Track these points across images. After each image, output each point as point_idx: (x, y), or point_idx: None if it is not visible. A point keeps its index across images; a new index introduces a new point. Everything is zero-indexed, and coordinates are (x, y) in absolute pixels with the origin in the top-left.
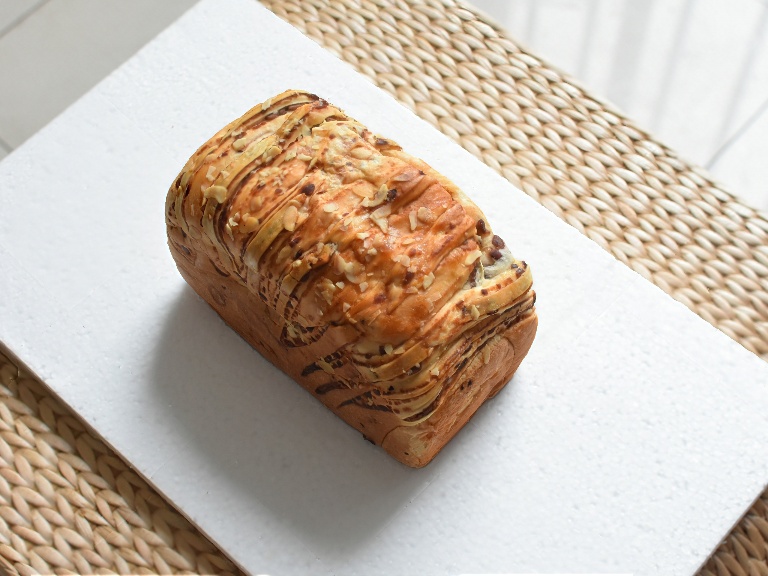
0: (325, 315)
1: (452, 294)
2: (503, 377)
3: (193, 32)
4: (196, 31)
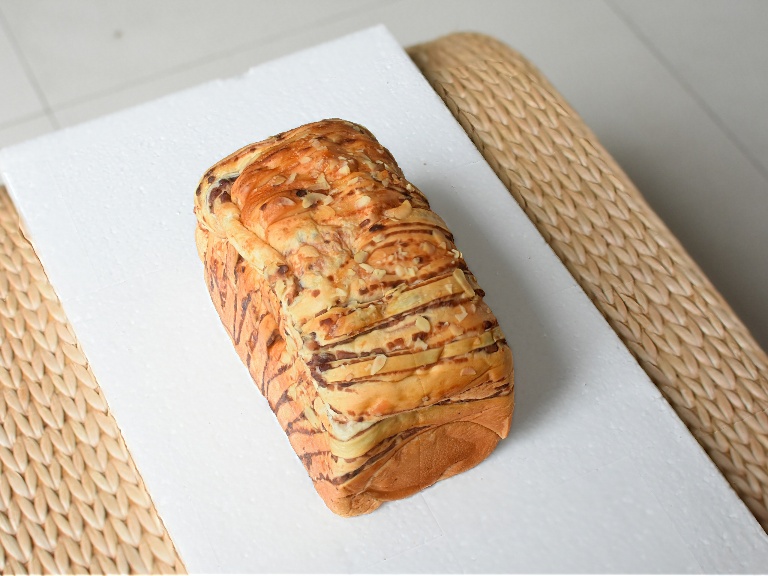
0: None
1: None
2: None
3: None
4: None
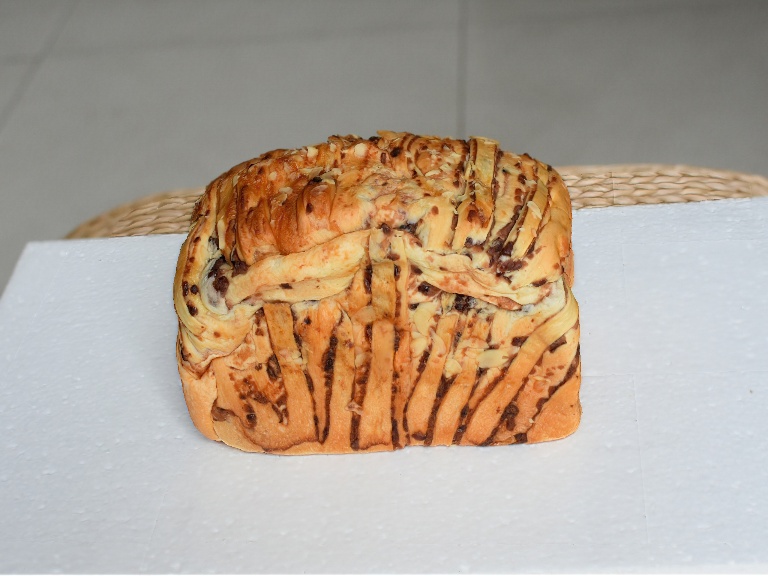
0: None
1: None
2: None
3: None
4: None
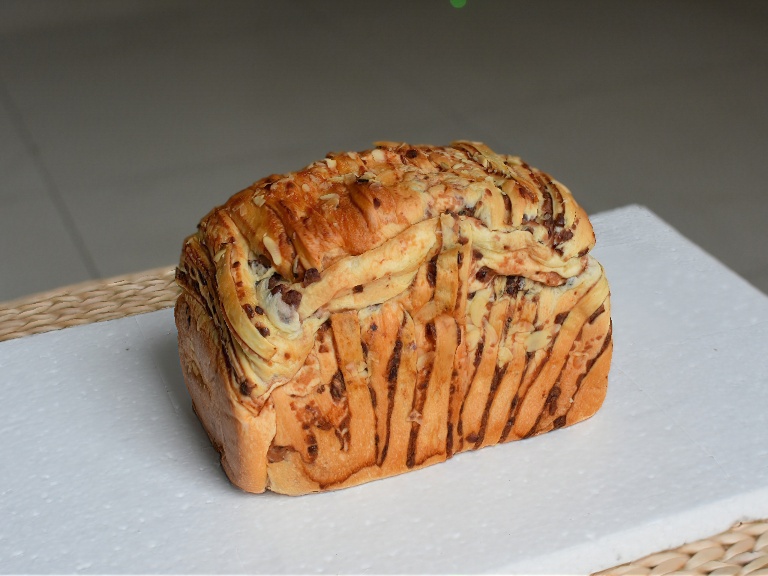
0: None
1: None
2: None
3: None
4: None
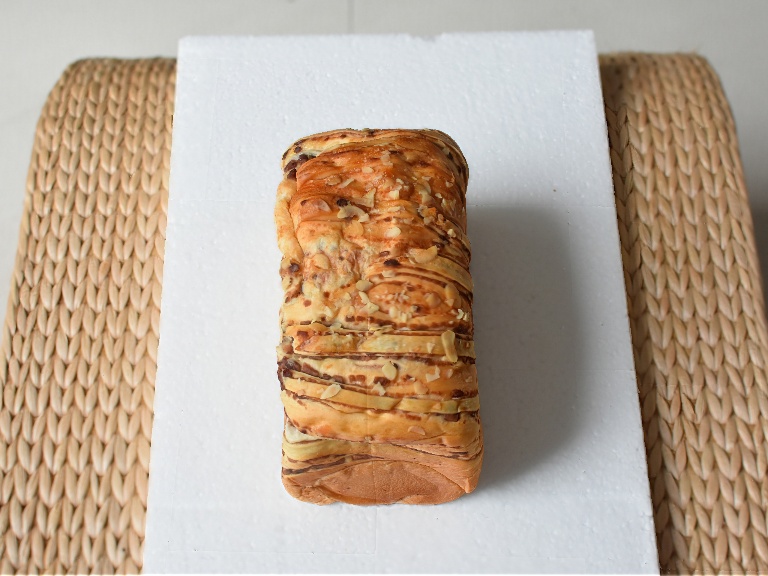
0: None
1: None
2: None
3: None
4: None
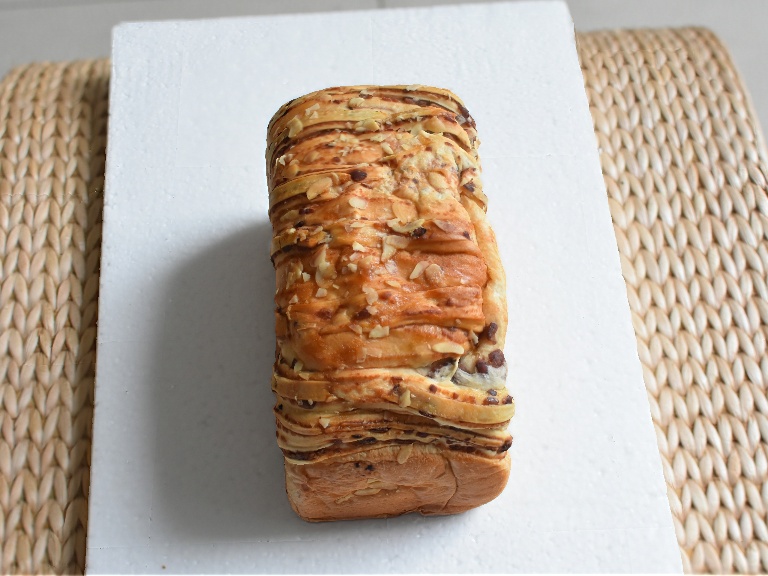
0: (278, 295)
1: (397, 365)
2: (443, 503)
3: (494, 21)
4: (497, 22)
